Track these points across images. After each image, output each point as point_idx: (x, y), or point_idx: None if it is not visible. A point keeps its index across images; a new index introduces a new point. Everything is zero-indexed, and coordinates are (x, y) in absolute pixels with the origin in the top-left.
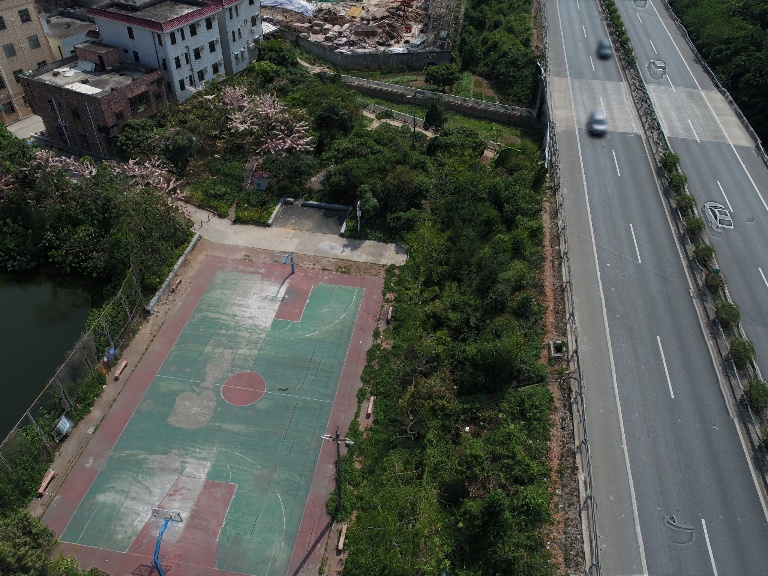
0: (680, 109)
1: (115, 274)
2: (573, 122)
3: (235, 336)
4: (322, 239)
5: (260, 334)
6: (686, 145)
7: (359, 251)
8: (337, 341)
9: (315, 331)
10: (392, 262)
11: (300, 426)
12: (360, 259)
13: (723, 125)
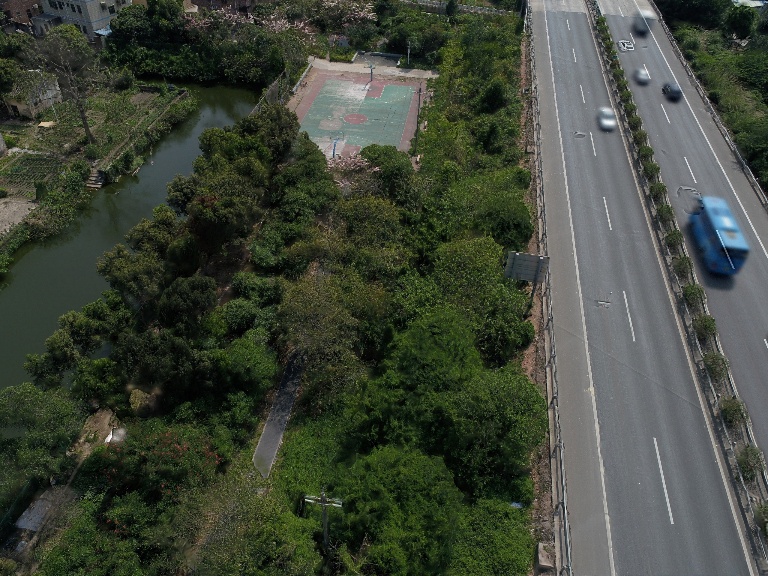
0: (614, 2)
1: (274, 71)
2: (543, 8)
3: (345, 102)
4: (386, 68)
5: (359, 102)
6: (614, 18)
7: (410, 73)
8: (403, 105)
9: (390, 101)
10: (430, 77)
11: (389, 130)
12: (411, 76)
13: (641, 9)
